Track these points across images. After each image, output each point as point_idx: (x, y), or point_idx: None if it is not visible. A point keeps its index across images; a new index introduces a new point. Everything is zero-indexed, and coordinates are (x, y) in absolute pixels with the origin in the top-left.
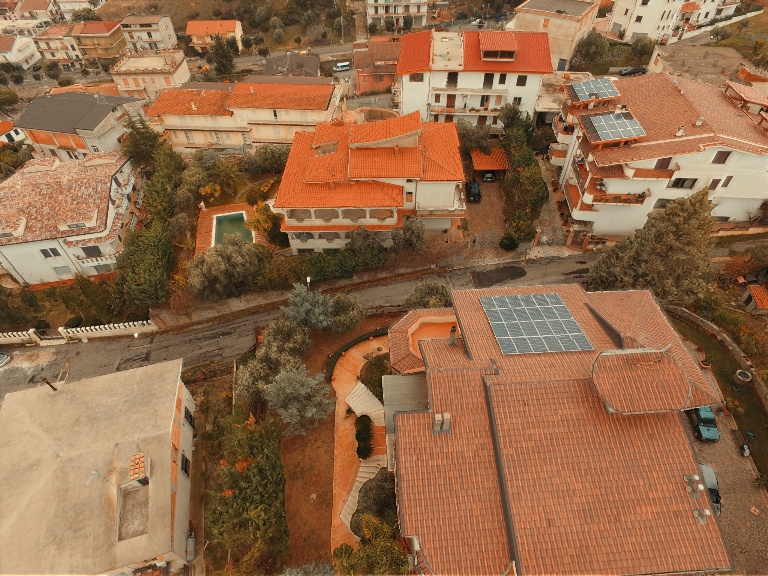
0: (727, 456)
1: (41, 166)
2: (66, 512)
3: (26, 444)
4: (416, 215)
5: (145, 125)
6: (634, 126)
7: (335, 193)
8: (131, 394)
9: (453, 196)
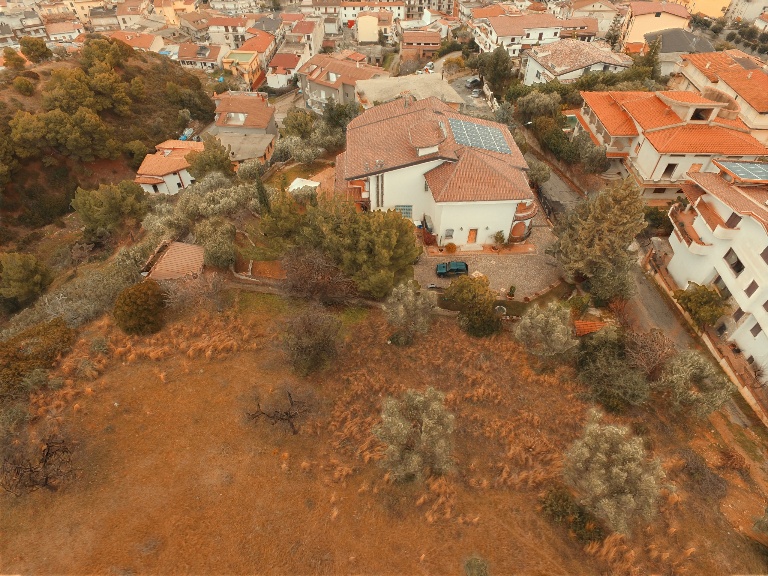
0: (428, 280)
1: (598, 44)
2: (390, 89)
3: (416, 77)
4: (625, 161)
5: (656, 51)
6: (762, 177)
7: (607, 107)
8: (442, 92)
9: (654, 168)
